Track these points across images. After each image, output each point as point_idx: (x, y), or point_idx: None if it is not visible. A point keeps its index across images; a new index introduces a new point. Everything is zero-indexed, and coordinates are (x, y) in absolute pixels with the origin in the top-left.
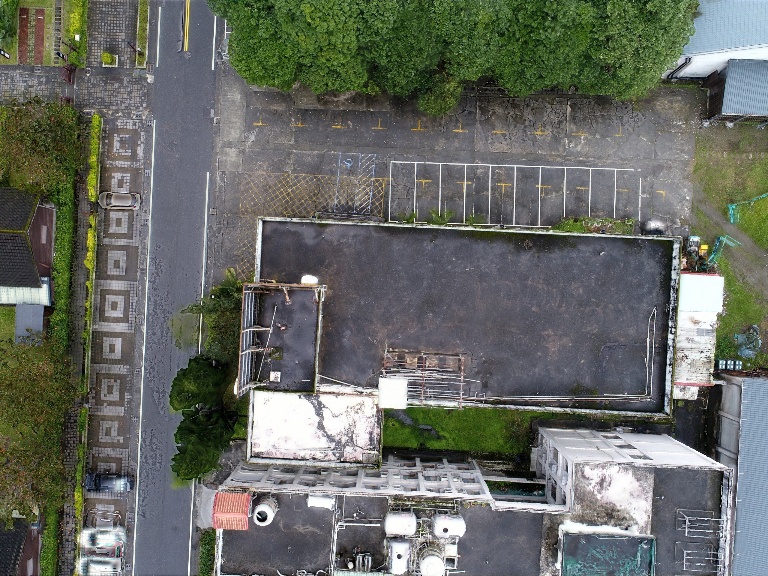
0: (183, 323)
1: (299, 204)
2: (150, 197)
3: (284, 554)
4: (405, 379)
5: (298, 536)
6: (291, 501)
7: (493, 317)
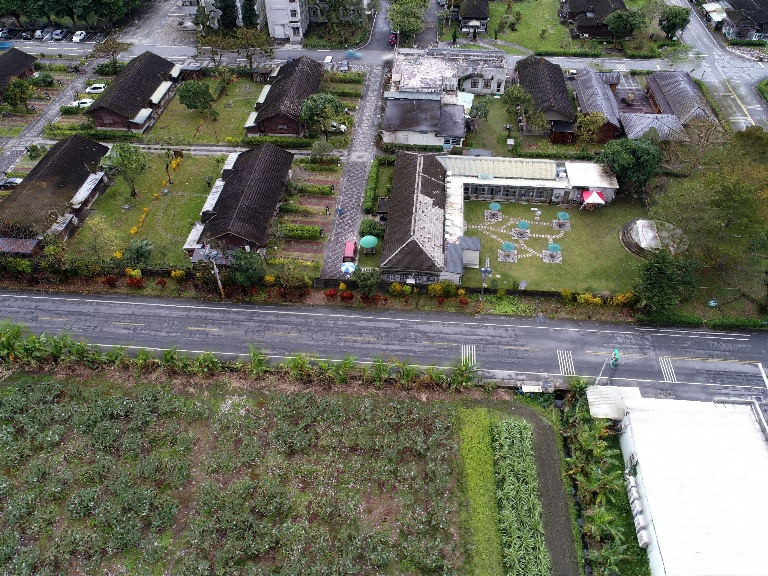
0: None
1: None
2: None
3: None
4: None
5: None
6: None
7: None
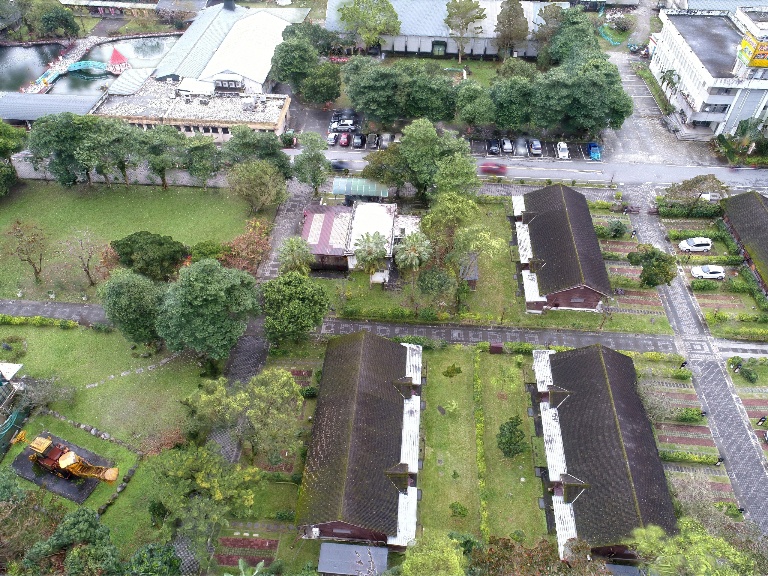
0: (759, 174)
1: None
2: None
3: None
4: None
5: None
6: None
7: None
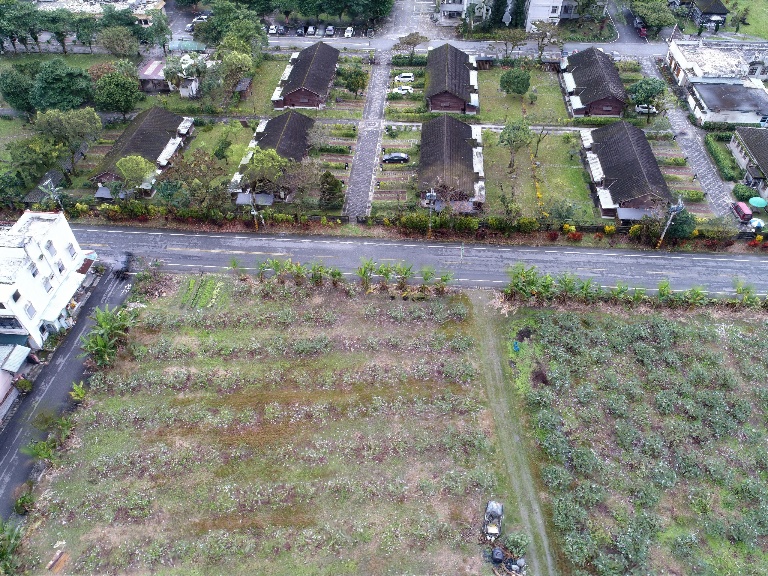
0: None
1: None
2: None
3: None
4: None
5: None
6: None
7: None
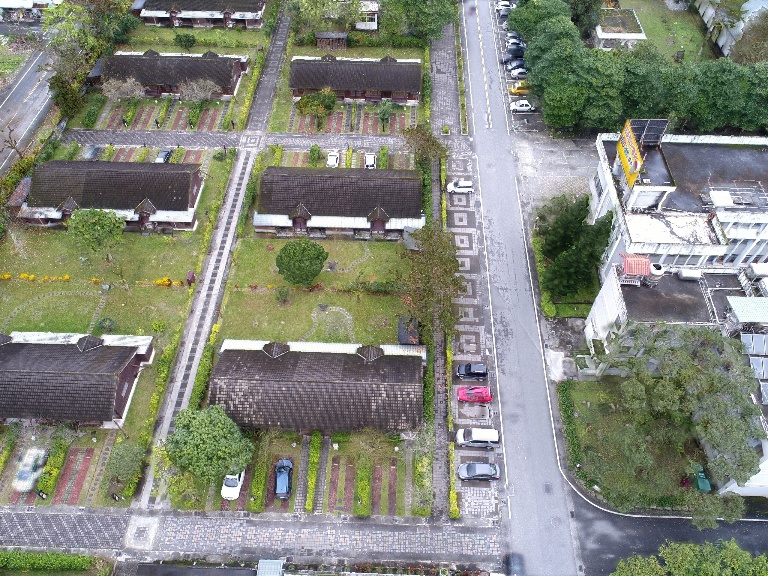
0: (514, 249)
1: (580, 189)
2: (479, 188)
3: (672, 312)
4: (727, 191)
5: (679, 300)
6: (665, 279)
7: (762, 180)
